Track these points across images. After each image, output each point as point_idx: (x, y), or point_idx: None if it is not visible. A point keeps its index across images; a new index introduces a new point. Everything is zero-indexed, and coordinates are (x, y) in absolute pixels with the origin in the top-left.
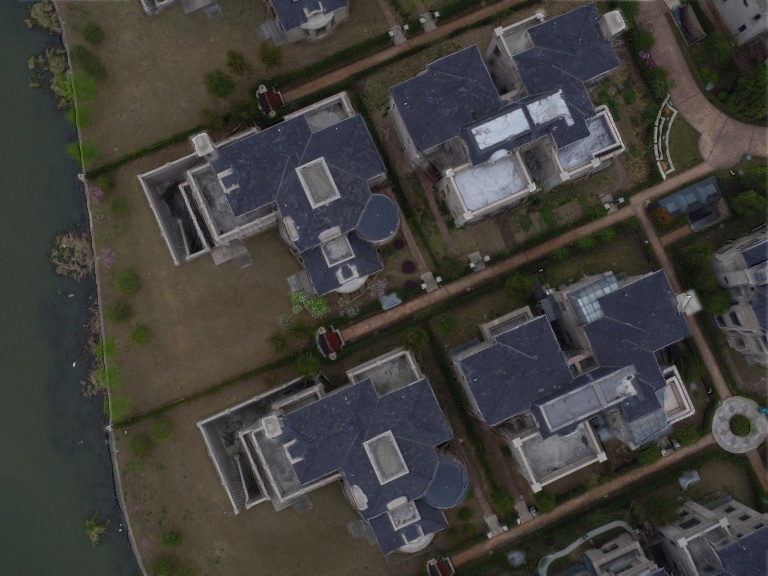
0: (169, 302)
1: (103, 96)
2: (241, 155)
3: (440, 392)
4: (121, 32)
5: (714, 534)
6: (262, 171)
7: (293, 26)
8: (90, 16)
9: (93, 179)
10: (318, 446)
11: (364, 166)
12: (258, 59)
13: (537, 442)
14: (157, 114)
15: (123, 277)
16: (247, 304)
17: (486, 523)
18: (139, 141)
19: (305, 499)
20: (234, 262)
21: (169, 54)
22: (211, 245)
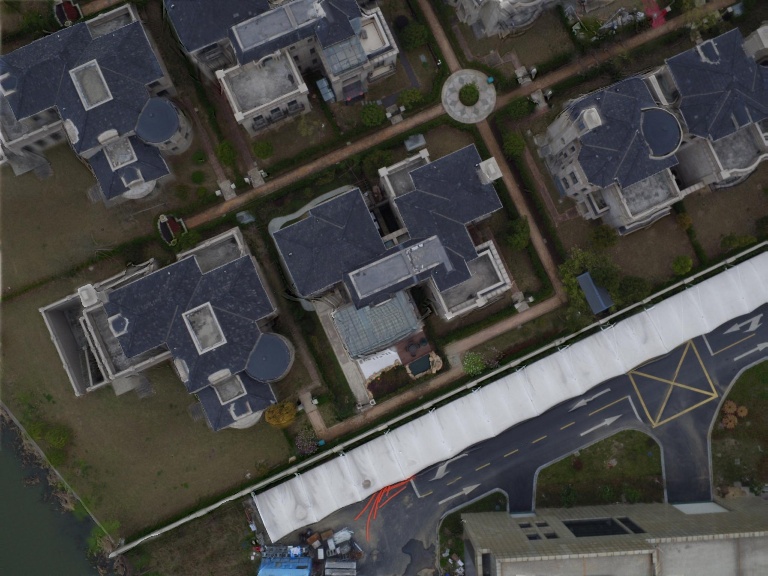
0: None
1: None
2: None
3: (154, 37)
4: None
5: (415, 165)
6: None
7: None
8: None
9: None
10: (26, 74)
11: None
12: None
13: (244, 80)
14: None
15: None
16: None
17: (220, 188)
18: None
19: (44, 164)
20: None
21: None
22: None
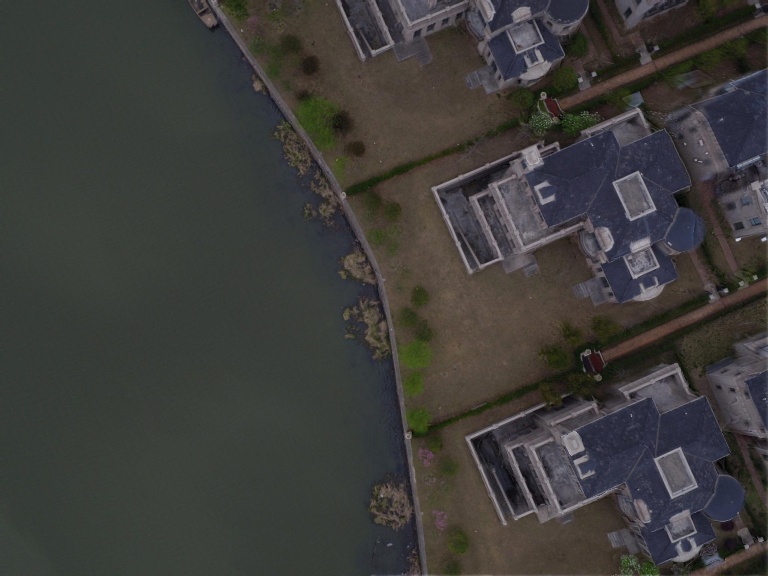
0: (495, 559)
1: (426, 354)
2: (597, 442)
3: None
4: (443, 291)
5: None
6: (620, 460)
7: (627, 299)
8: (411, 274)
9: (418, 437)
10: None
11: (714, 451)
12: (577, 318)
13: None
14: (480, 373)
15: (458, 541)
16: (569, 560)
17: None
18: (463, 400)
19: None
20: (557, 519)
21: (489, 312)
22: (537, 505)
